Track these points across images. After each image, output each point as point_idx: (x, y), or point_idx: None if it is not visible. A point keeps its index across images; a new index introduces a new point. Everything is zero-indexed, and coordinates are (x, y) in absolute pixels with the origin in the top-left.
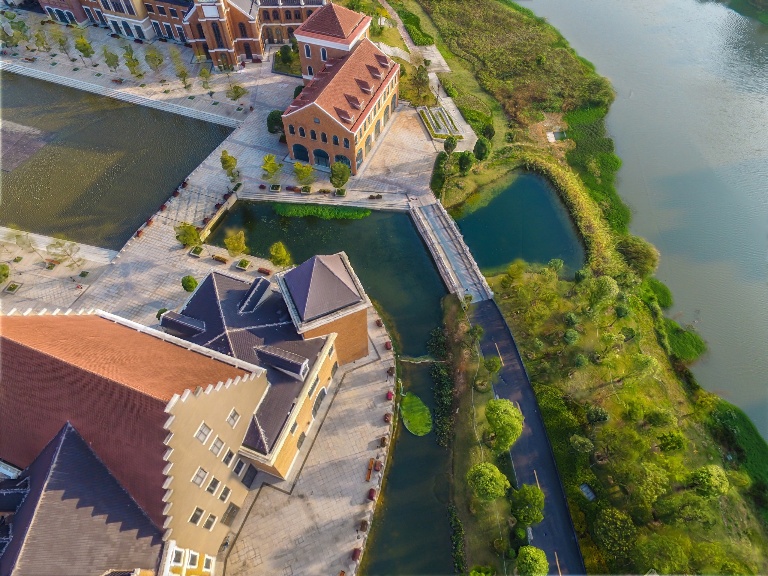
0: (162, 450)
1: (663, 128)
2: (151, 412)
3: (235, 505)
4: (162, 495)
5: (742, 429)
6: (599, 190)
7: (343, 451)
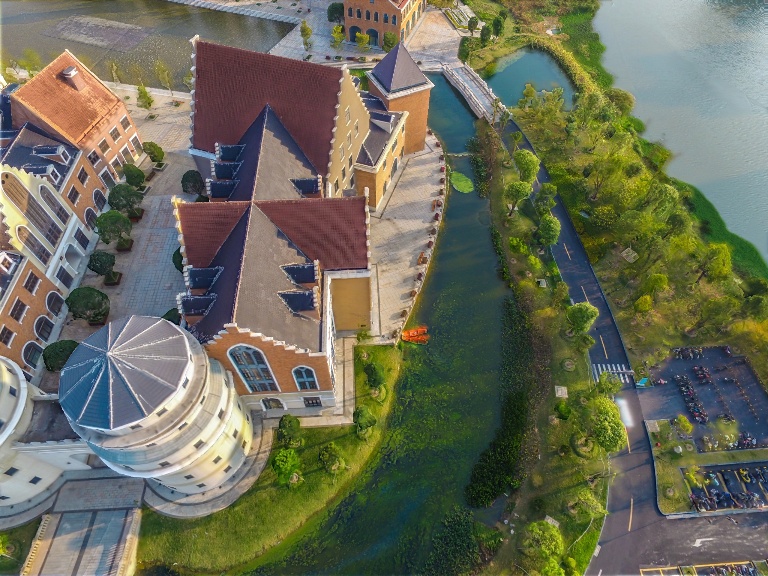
0: (332, 108)
1: (638, 26)
2: (328, 79)
3: None
4: (329, 142)
5: (693, 195)
6: (588, 65)
7: (414, 197)
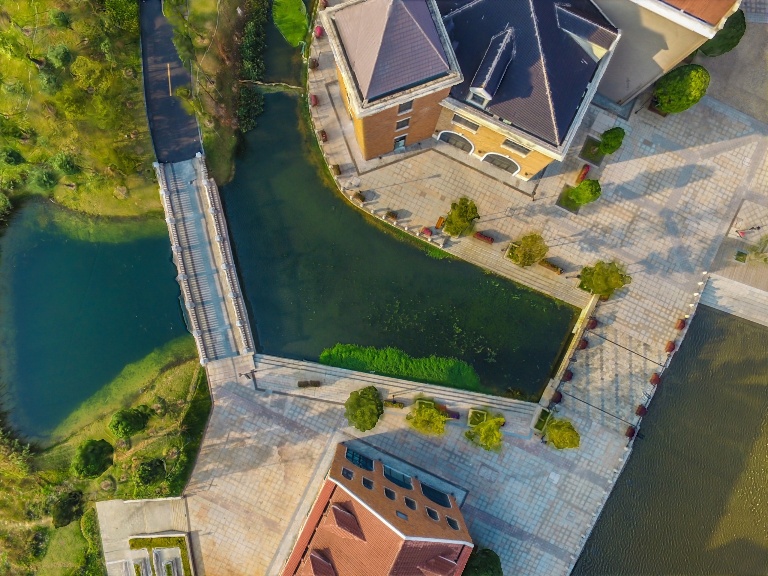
0: None
1: None
2: None
3: None
4: None
5: None
6: None
7: None
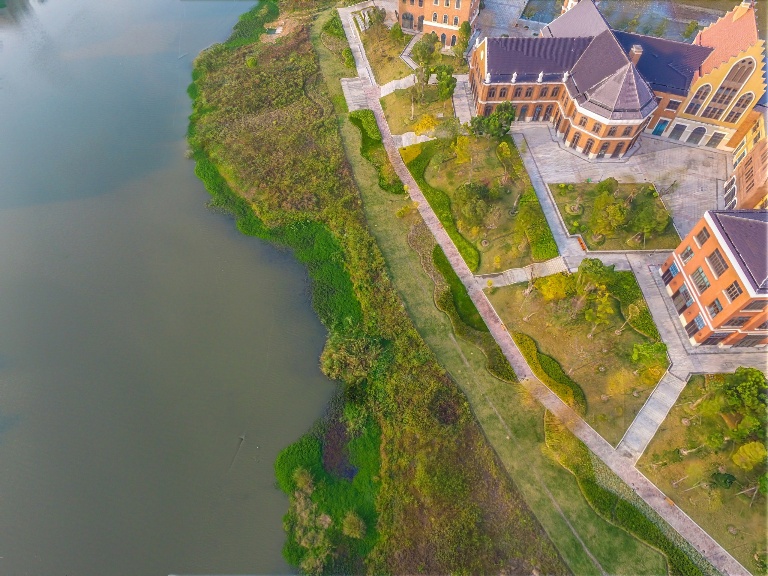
0: None
1: (185, 33)
2: None
3: None
4: None
5: None
6: (269, 2)
7: None
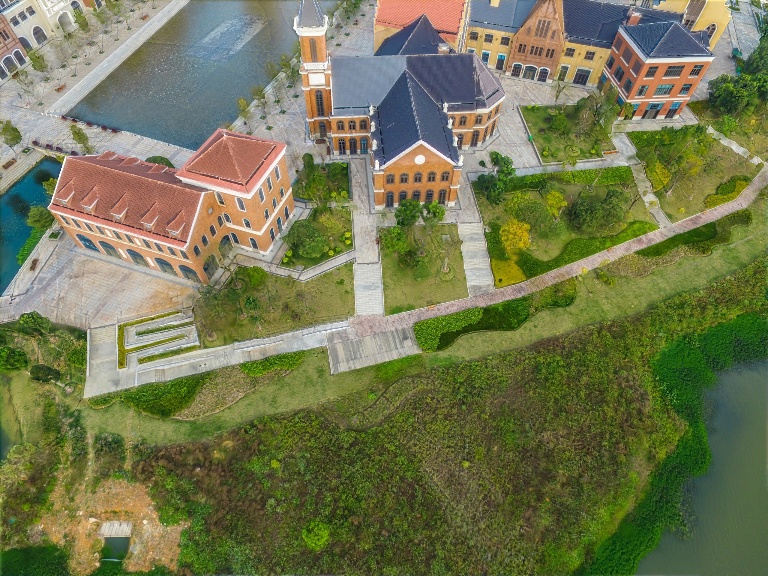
0: None
1: None
2: None
3: None
4: None
5: None
6: None
7: None
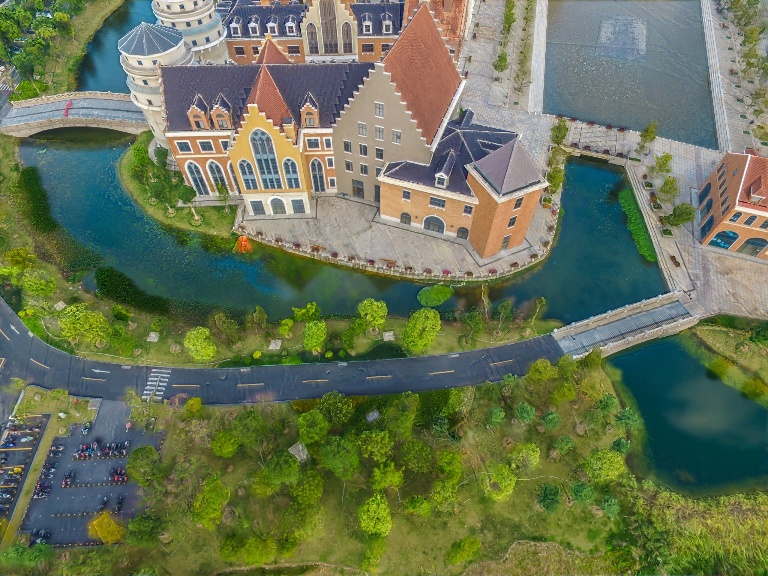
0: None
1: None
2: None
3: (364, 191)
4: None
5: None
6: None
7: (401, 246)
